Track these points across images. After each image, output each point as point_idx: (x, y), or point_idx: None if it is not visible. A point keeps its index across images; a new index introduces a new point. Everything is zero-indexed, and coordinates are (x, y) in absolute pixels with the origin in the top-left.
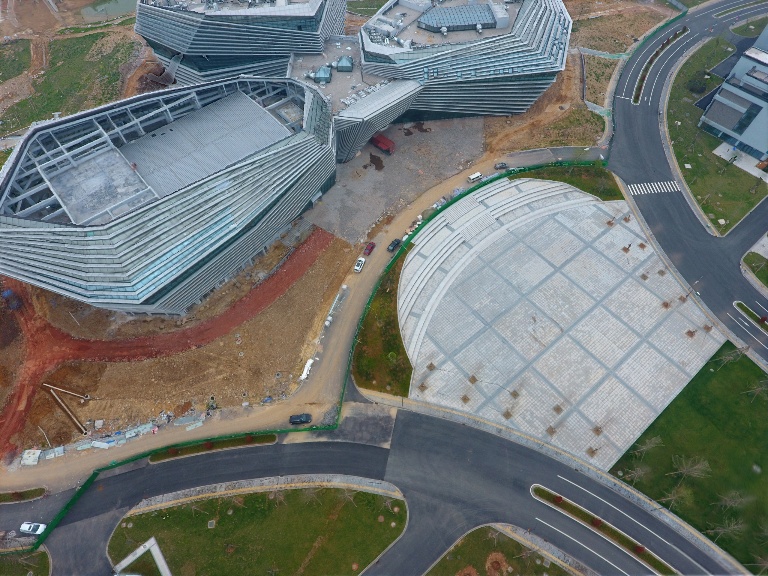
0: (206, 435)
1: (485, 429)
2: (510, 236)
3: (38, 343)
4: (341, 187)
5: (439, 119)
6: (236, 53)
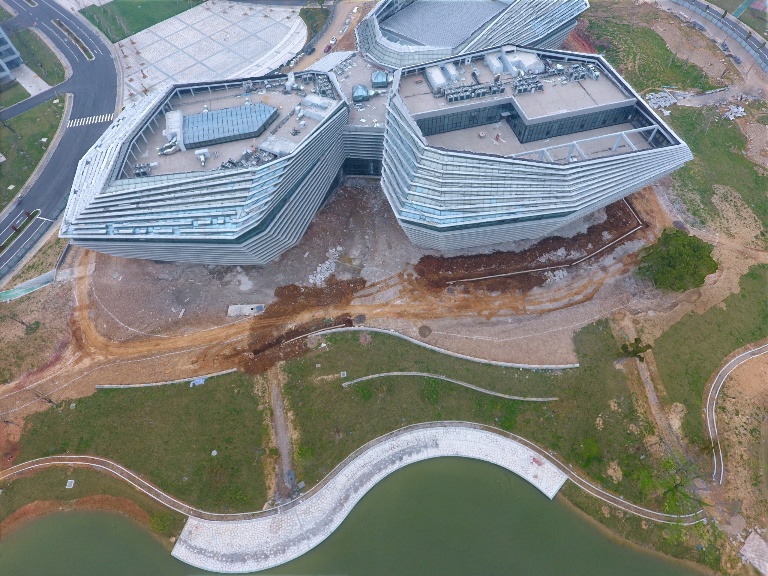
0: None
1: None
2: (226, 76)
3: None
4: None
5: None
6: None
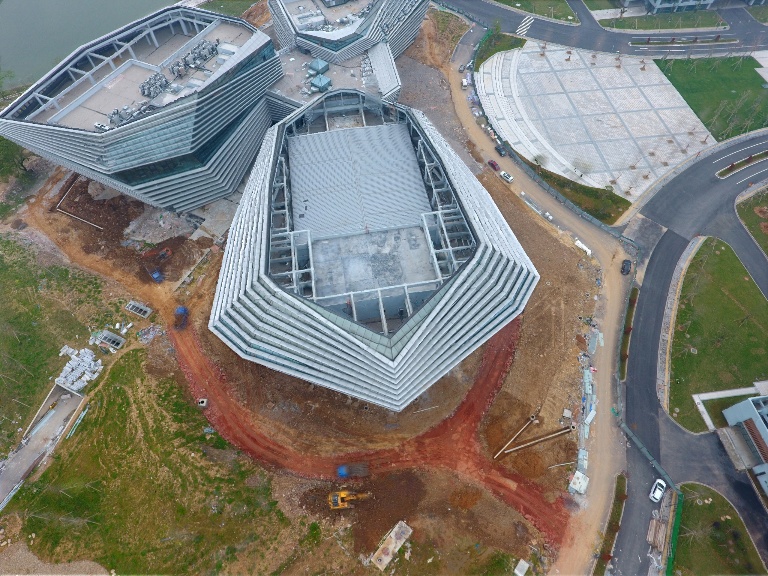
0: (614, 333)
1: (671, 178)
2: (523, 99)
3: (438, 454)
4: None
5: None
6: (229, 120)
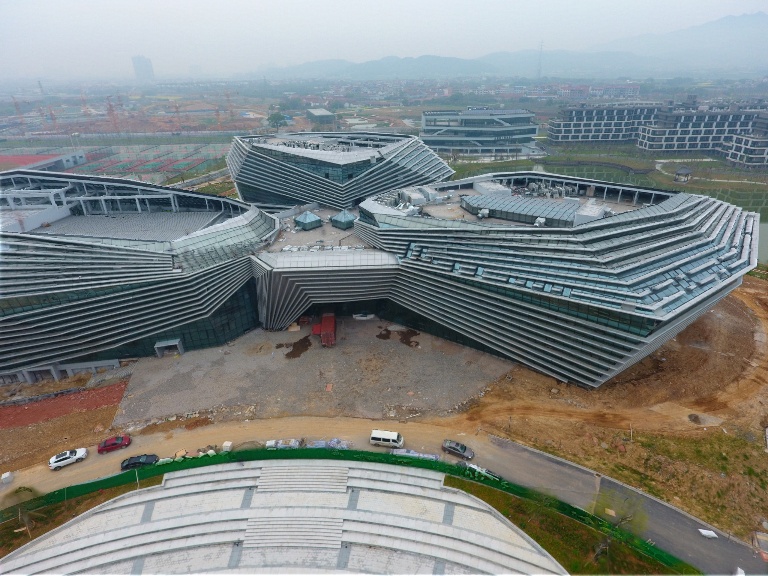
0: None
1: None
2: None
3: None
4: (222, 352)
5: (443, 337)
6: (270, 189)
